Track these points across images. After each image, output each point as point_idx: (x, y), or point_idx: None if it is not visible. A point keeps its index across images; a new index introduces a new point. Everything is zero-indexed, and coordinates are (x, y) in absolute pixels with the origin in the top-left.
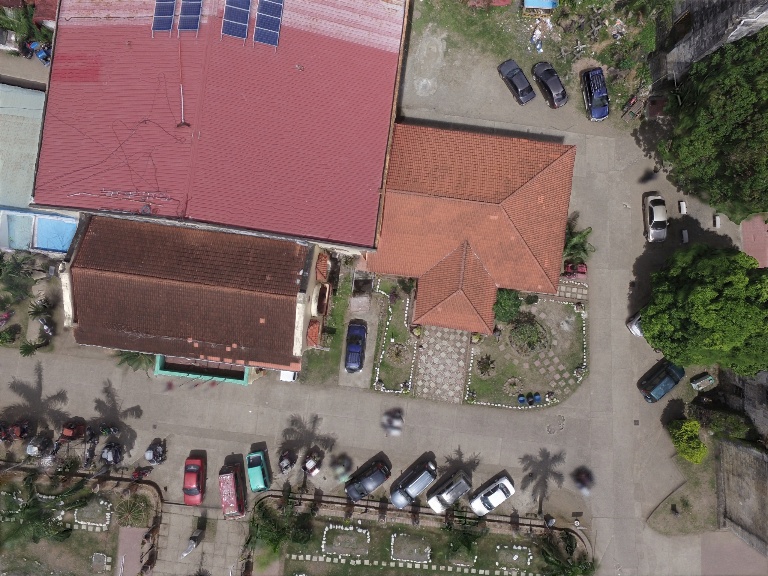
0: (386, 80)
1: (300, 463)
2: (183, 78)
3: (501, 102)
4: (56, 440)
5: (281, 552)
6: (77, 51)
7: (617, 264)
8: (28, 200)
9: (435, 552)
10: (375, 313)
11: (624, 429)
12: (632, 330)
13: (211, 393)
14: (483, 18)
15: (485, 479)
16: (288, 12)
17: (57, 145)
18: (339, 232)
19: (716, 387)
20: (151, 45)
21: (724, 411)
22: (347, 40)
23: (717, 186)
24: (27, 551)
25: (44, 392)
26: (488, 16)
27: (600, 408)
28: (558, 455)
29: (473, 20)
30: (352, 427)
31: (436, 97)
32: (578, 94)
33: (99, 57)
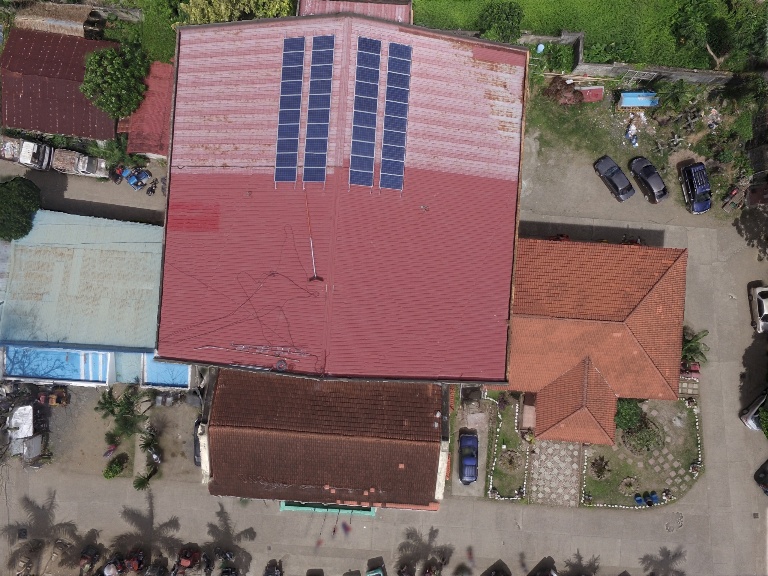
0: (507, 209)
1: None
2: (312, 231)
3: (598, 199)
4: (172, 569)
5: None
6: (193, 200)
7: (726, 356)
8: (138, 338)
9: None
10: None
11: (744, 523)
12: (748, 424)
13: None
14: (575, 115)
15: None
16: (410, 153)
17: (179, 296)
18: (471, 368)
19: None
20: (274, 196)
21: None
22: (468, 174)
23: None
24: None
25: (155, 520)
26: (580, 113)
27: (718, 503)
28: (678, 553)
29: (565, 118)
30: (468, 537)
31: (532, 198)
32: (677, 187)
33: (218, 207)
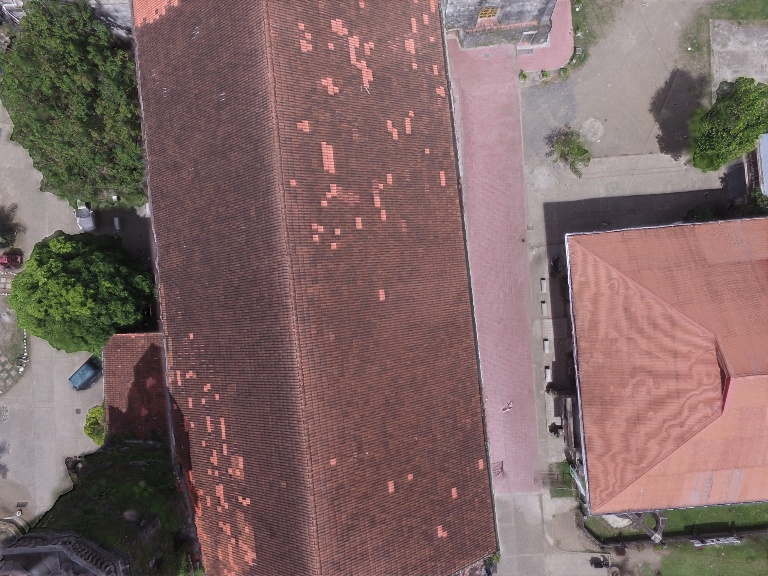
0: None
1: None
2: None
3: None
4: None
5: None
6: None
7: None
8: None
9: None
10: None
11: (66, 418)
12: None
13: None
14: None
15: None
16: None
17: None
18: None
19: None
20: None
21: None
22: None
23: None
24: None
25: None
26: None
27: (42, 398)
28: (2, 446)
29: None
30: None
31: None
32: None
33: None
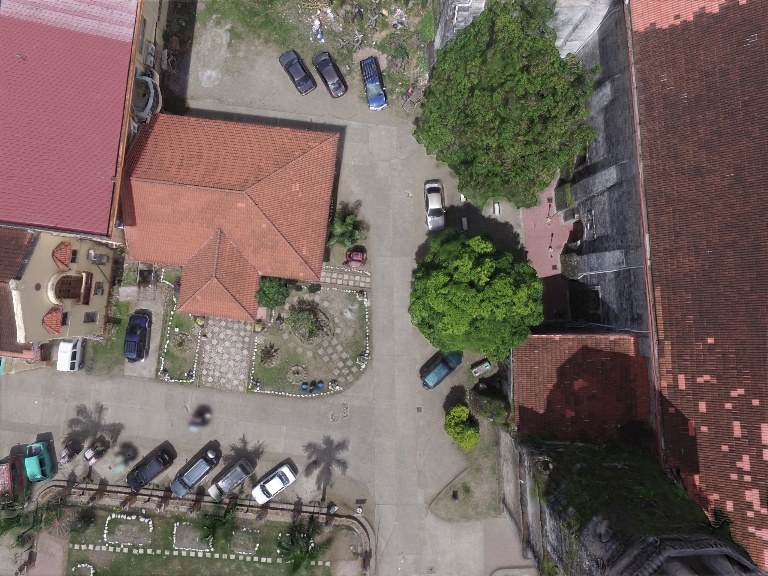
0: (119, 69)
1: None
2: None
3: (284, 92)
4: None
5: (65, 542)
6: None
7: (400, 252)
8: None
9: (217, 540)
10: (160, 303)
11: (407, 416)
12: None
13: None
14: (266, 9)
15: (269, 467)
16: (8, 2)
17: None
18: (69, 220)
19: (496, 373)
20: None
21: (491, 396)
22: (74, 29)
23: (462, 172)
24: None
25: None
26: (270, 7)
27: (383, 395)
28: (342, 443)
29: (256, 11)
30: (137, 417)
31: (220, 88)
32: (359, 84)
33: None
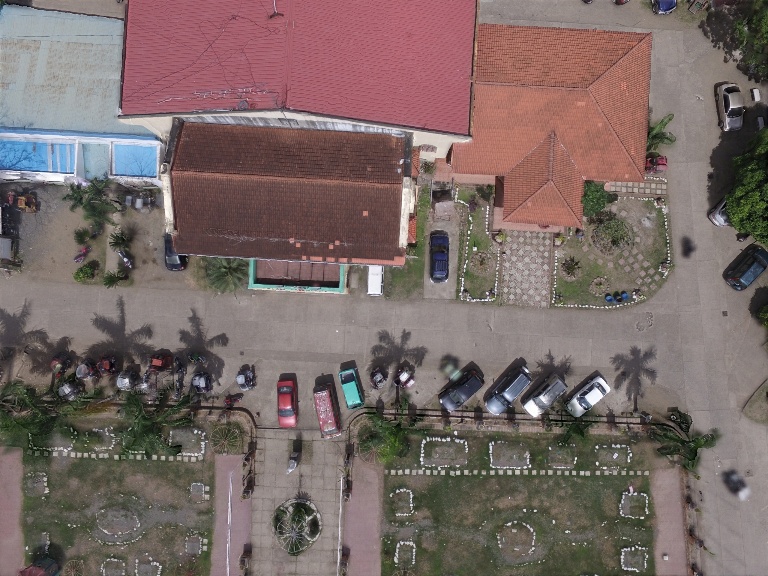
0: None
1: (391, 379)
2: None
3: (566, 3)
4: (144, 373)
5: (379, 469)
6: None
7: (694, 157)
8: (105, 125)
9: (534, 457)
10: (455, 223)
11: (713, 321)
12: (715, 220)
13: (296, 315)
14: None
15: (578, 381)
16: None
17: (142, 54)
18: (434, 121)
19: None
20: None
21: None
22: None
23: None
24: (123, 487)
25: (127, 327)
26: None
27: (688, 302)
28: (649, 352)
29: None
30: (441, 339)
31: (500, 2)
32: None
33: None
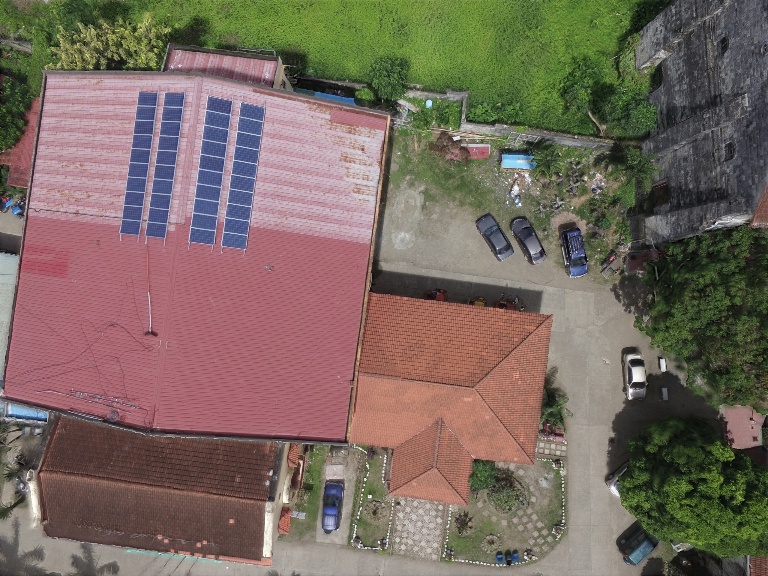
0: (358, 271)
1: None
2: (151, 285)
3: (479, 256)
4: None
5: None
6: (47, 243)
7: (596, 420)
8: (2, 371)
9: None
10: (352, 469)
11: None
12: (611, 490)
13: None
14: (461, 171)
15: None
16: (257, 213)
17: (27, 338)
18: (310, 428)
19: None
20: (119, 248)
21: None
22: (318, 235)
23: (694, 368)
24: None
25: (21, 547)
26: (466, 170)
27: (579, 566)
28: None
29: (451, 173)
30: None
31: (414, 251)
32: (557, 249)
33: (68, 253)
